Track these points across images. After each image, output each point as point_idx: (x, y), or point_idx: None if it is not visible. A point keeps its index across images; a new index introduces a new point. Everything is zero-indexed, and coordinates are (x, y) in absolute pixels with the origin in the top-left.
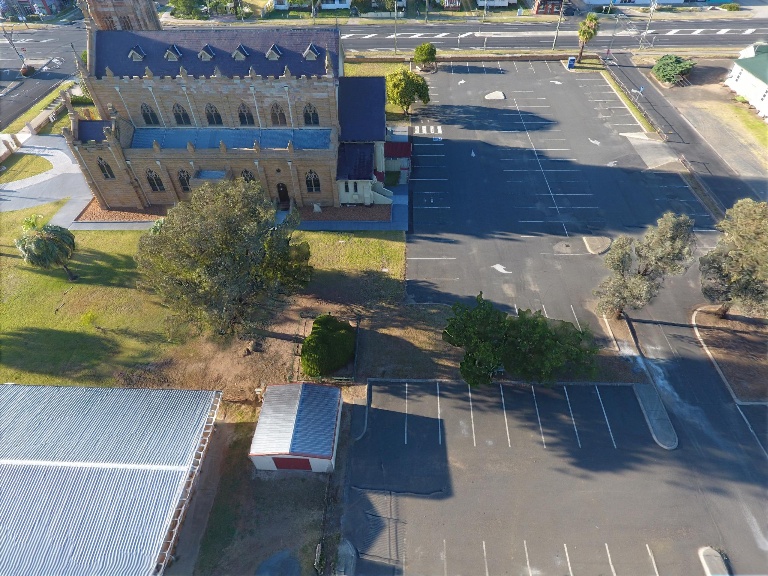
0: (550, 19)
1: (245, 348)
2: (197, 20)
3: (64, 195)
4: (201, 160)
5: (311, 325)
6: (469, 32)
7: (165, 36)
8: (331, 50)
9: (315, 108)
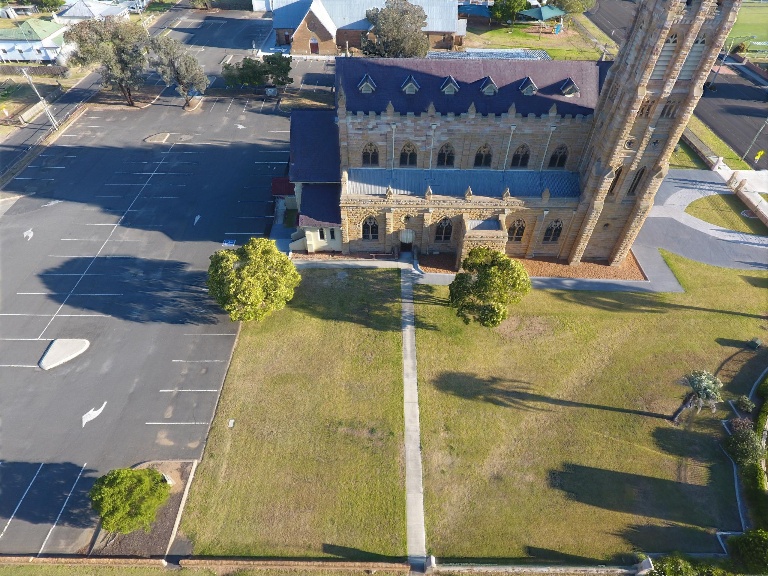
0: None
1: None
2: None
3: None
4: None
5: None
6: None
7: None
8: None
9: None
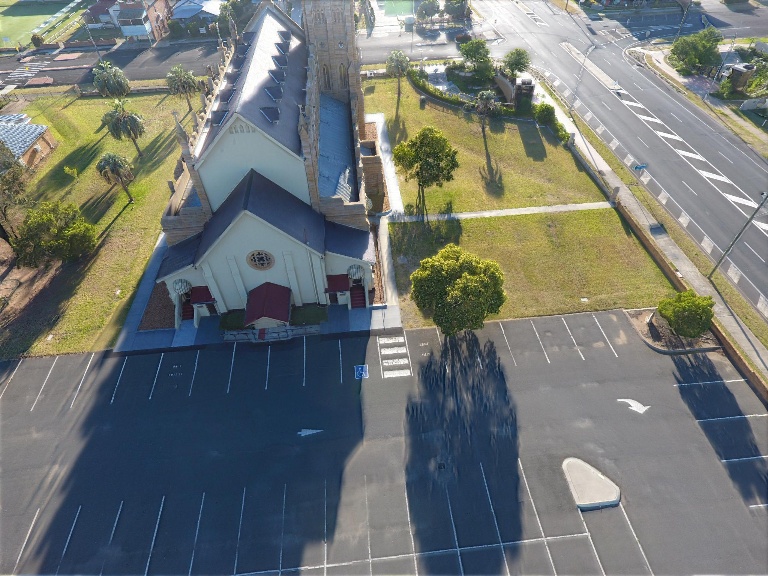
0: None
1: (3, 256)
2: (675, 70)
3: None
4: None
5: (6, 292)
6: None
7: None
8: None
9: None
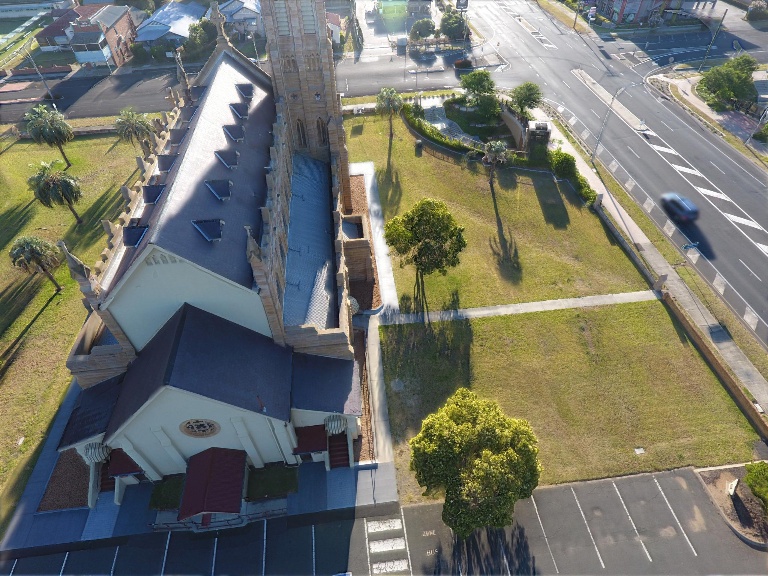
0: None
1: None
2: (706, 105)
3: None
4: None
5: None
6: None
7: None
8: None
9: None
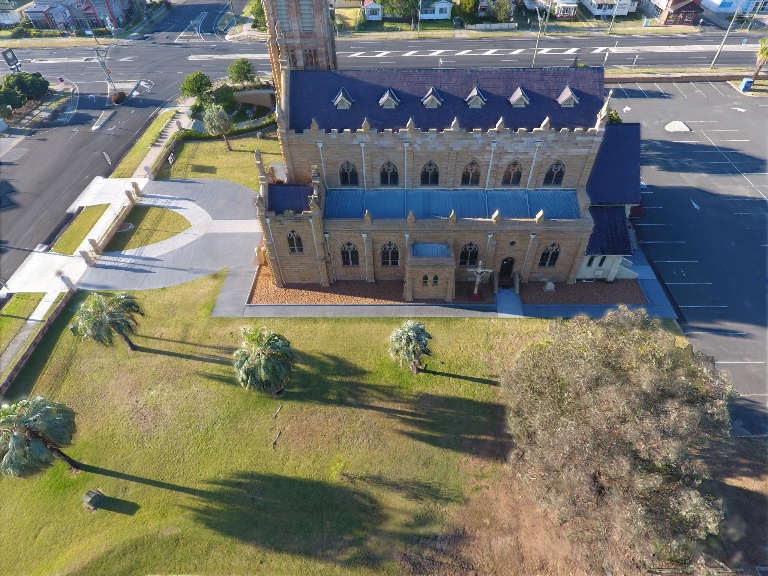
0: (684, 30)
1: None
2: None
3: (219, 265)
4: (420, 232)
5: None
6: (602, 47)
7: (378, 77)
8: (594, 94)
9: (563, 166)
